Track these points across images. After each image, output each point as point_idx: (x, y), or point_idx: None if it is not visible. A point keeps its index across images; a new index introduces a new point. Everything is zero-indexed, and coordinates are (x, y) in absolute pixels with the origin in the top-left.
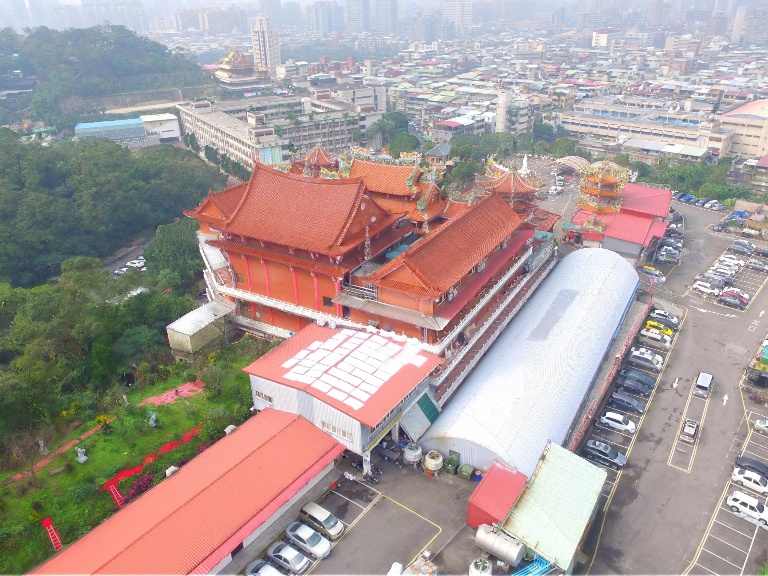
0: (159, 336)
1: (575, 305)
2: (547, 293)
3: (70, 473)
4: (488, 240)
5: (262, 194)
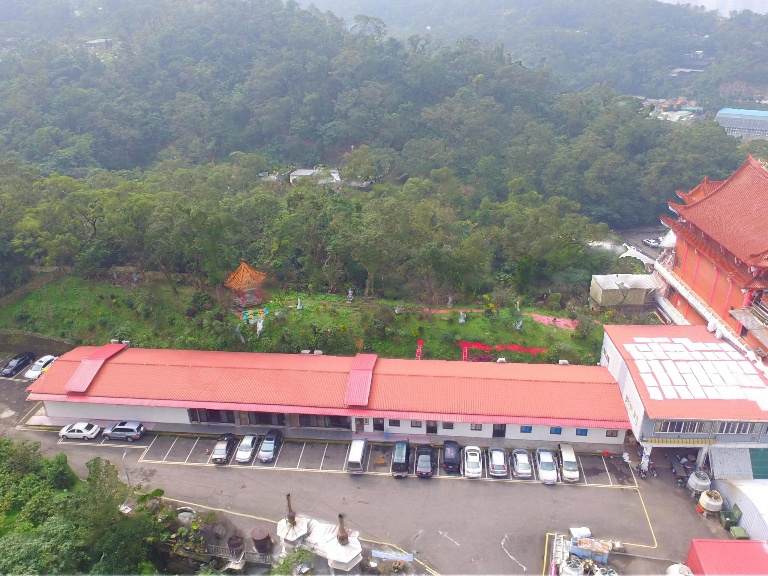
0: (590, 283)
1: None
2: None
3: (450, 324)
4: None
5: (736, 189)
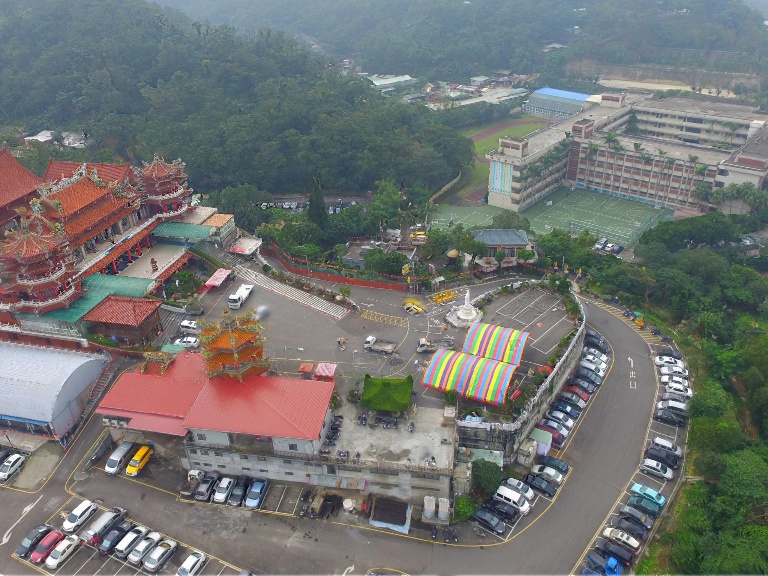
0: None
1: None
2: None
3: None
4: None
5: None
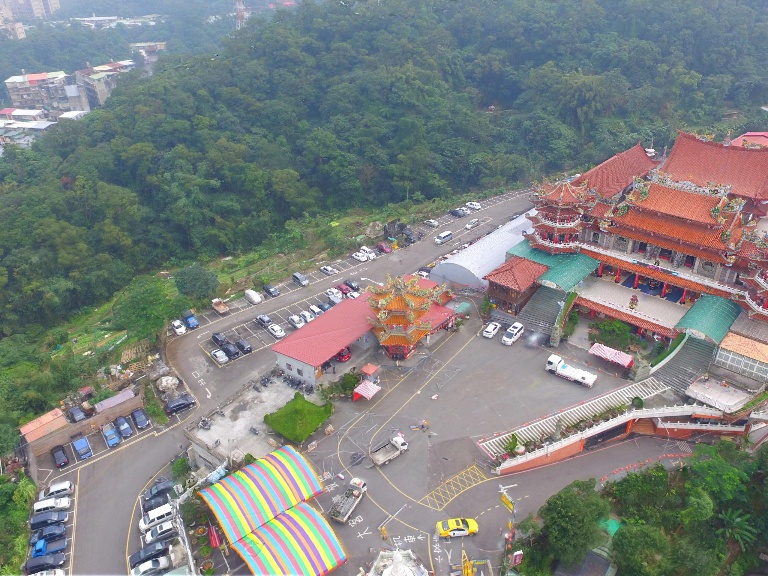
0: None
1: None
2: None
3: None
4: None
5: None
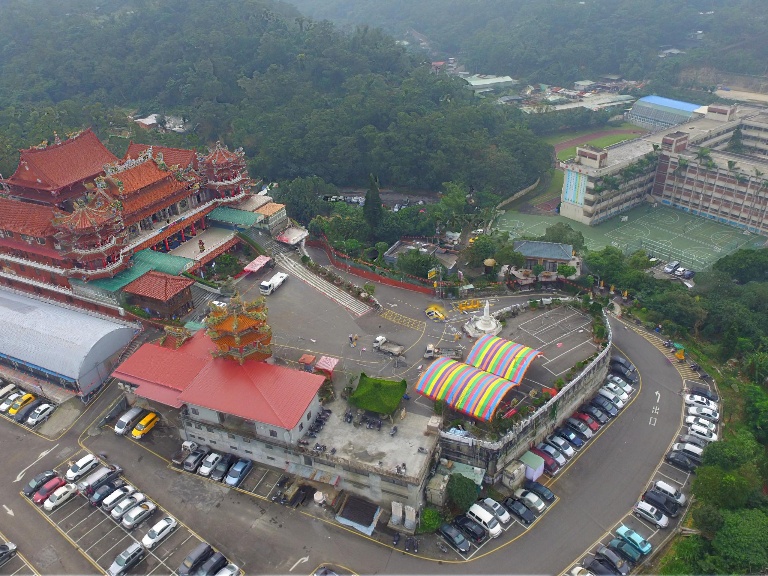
0: None
1: (7, 311)
2: (44, 304)
3: None
4: (6, 223)
5: None
